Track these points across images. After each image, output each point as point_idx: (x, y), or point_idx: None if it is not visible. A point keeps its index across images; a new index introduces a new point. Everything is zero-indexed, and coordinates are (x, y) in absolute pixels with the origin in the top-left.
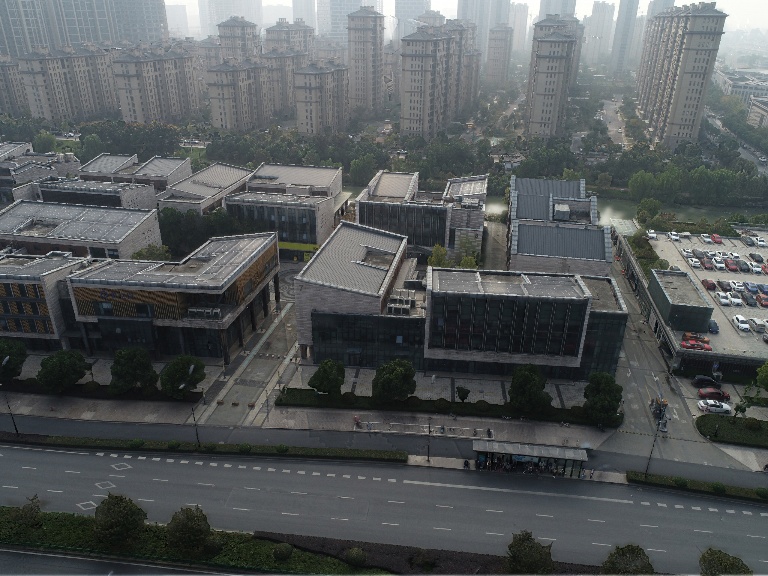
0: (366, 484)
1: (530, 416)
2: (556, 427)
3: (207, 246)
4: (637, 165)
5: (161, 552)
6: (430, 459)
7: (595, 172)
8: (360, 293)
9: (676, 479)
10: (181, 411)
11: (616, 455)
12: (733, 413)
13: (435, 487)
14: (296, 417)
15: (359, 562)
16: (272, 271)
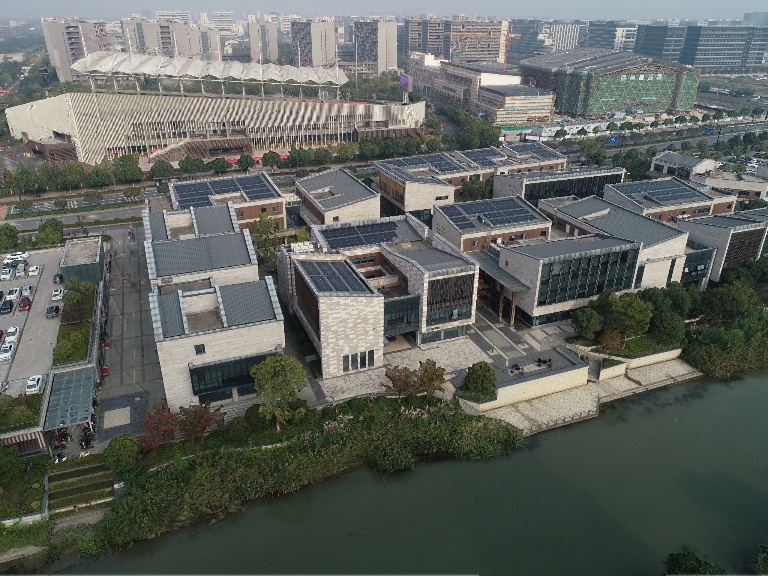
0: None
1: None
2: None
3: None
4: None
5: None
6: None
7: None
8: None
9: None
10: None
11: None
12: None
13: None
14: None
15: None
16: (400, 203)
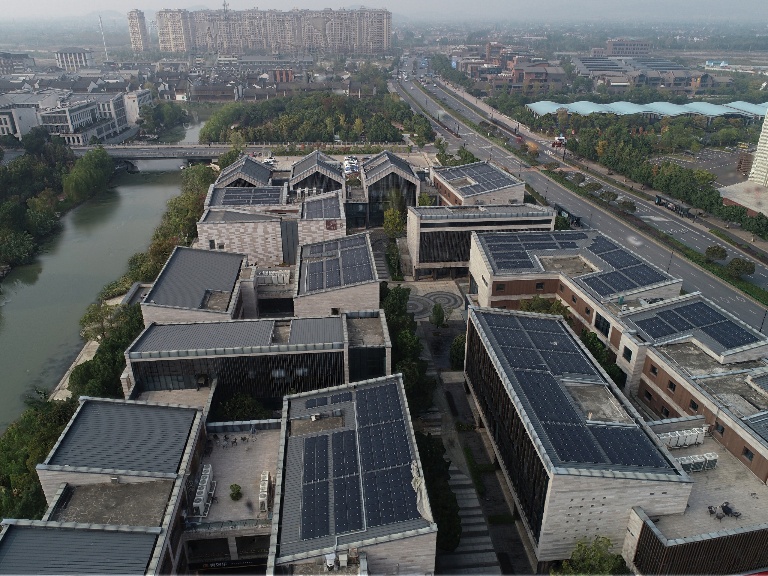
0: None
1: None
2: None
3: (510, 271)
4: (20, 177)
5: None
6: None
7: None
8: None
9: (542, 197)
10: None
11: None
12: None
13: None
14: None
15: None
16: None
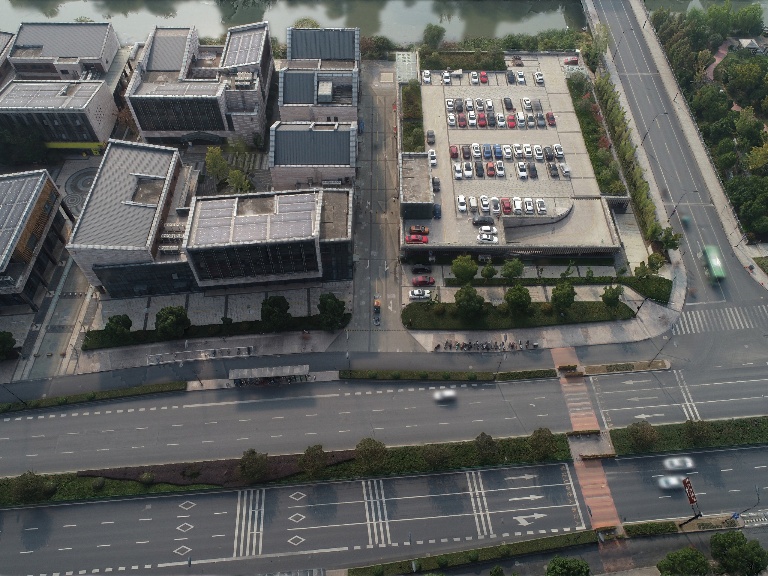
0: (156, 414)
1: (280, 329)
2: (299, 335)
3: None
4: None
5: (15, 500)
6: (203, 383)
7: None
8: (129, 250)
9: (369, 374)
10: (6, 370)
11: (338, 354)
12: (432, 297)
13: (205, 407)
14: (101, 359)
15: (149, 482)
16: (54, 206)
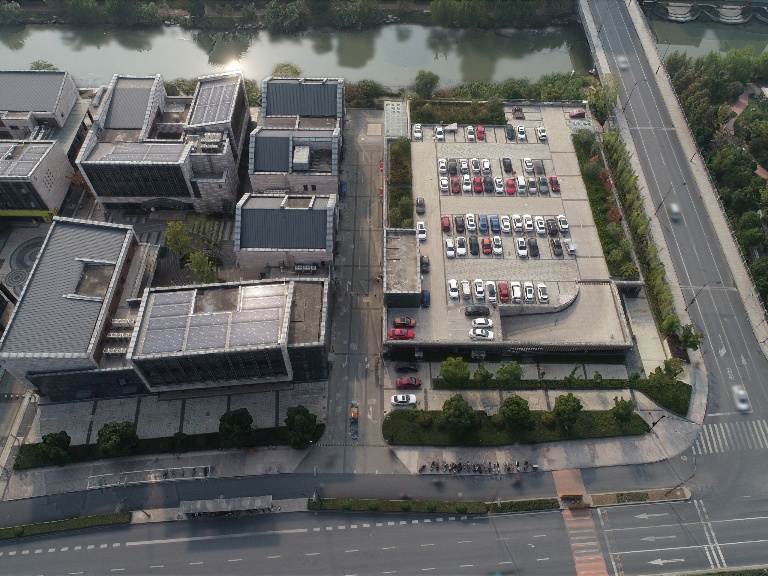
0: (94, 554)
1: (243, 445)
2: (265, 451)
3: None
4: None
5: None
6: (151, 514)
7: None
8: (66, 358)
9: (343, 504)
10: None
11: (308, 476)
12: None
13: (152, 546)
14: (34, 482)
15: None
16: None
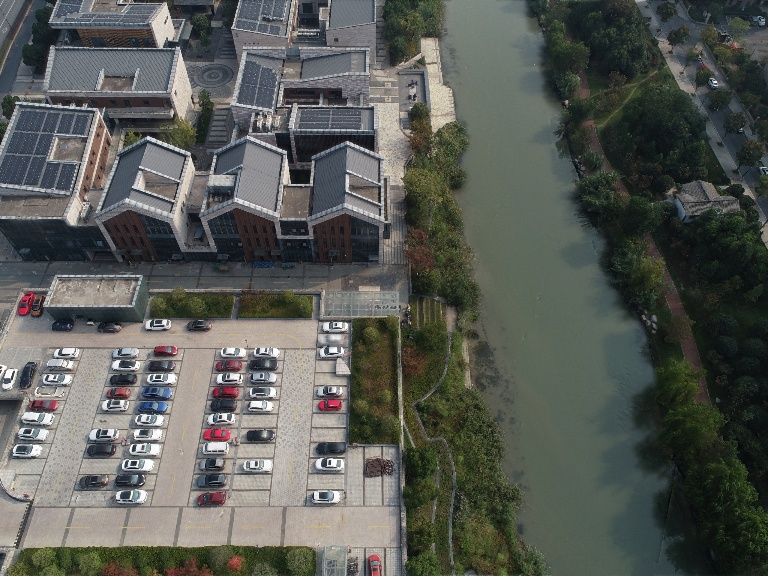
0: None
1: None
2: None
3: (151, 5)
4: None
5: None
6: None
7: (721, 316)
8: None
9: None
10: (28, 71)
11: None
12: None
13: None
14: None
15: None
16: None
